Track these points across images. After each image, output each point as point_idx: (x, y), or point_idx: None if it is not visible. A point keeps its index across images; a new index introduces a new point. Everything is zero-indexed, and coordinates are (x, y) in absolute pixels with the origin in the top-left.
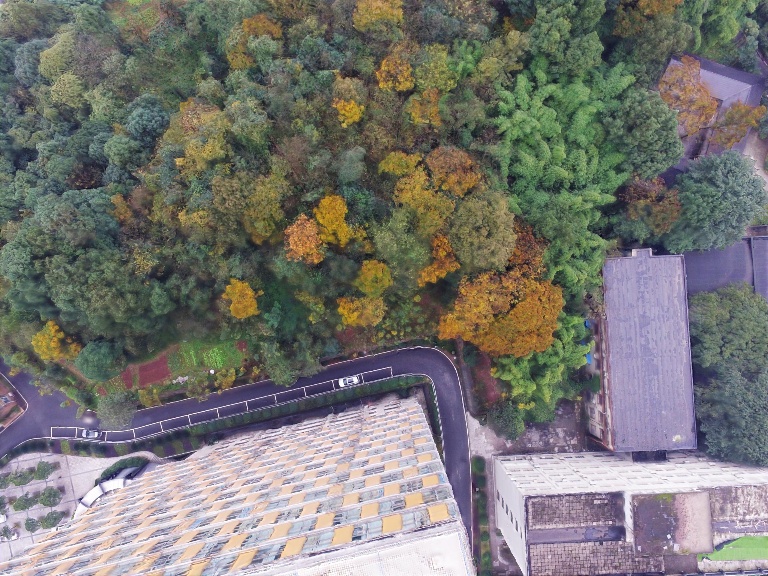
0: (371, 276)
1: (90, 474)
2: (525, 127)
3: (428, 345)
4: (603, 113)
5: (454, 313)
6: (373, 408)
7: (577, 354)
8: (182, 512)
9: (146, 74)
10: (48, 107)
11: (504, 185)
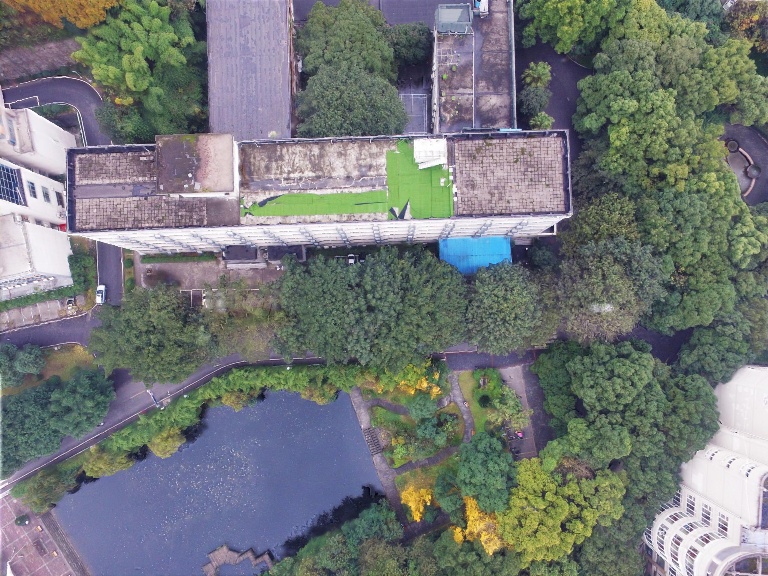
0: None
1: None
2: None
3: (73, 75)
4: None
5: None
6: None
7: (160, 40)
8: None
9: None
10: None
11: None
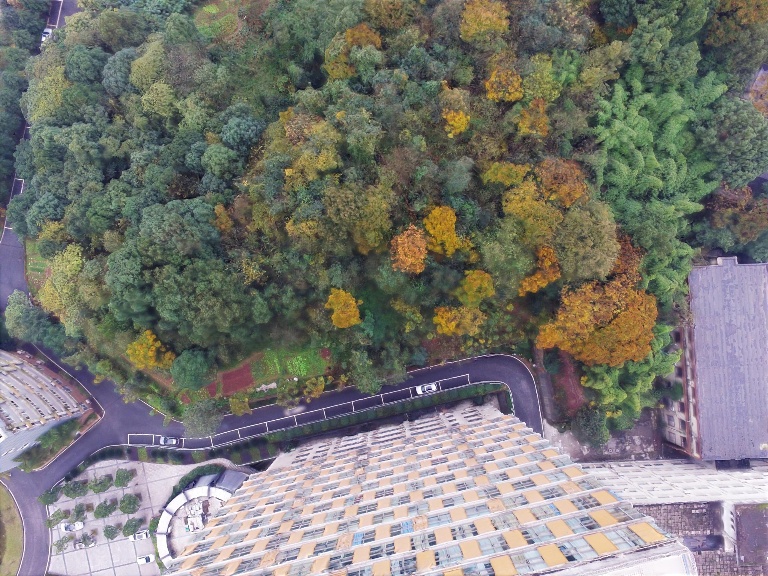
0: (477, 286)
1: (167, 481)
2: (622, 136)
3: (505, 352)
4: (694, 122)
5: (555, 323)
6: (449, 415)
7: (667, 363)
8: (329, 525)
9: (229, 82)
10: (139, 116)
11: (598, 194)
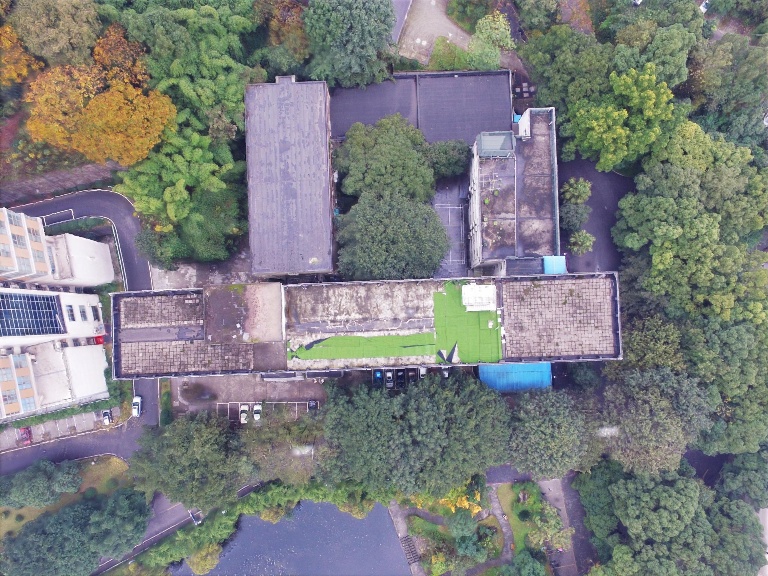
0: None
1: None
2: None
3: (108, 188)
4: None
5: (34, 109)
6: None
7: (202, 171)
8: None
9: None
10: None
11: None
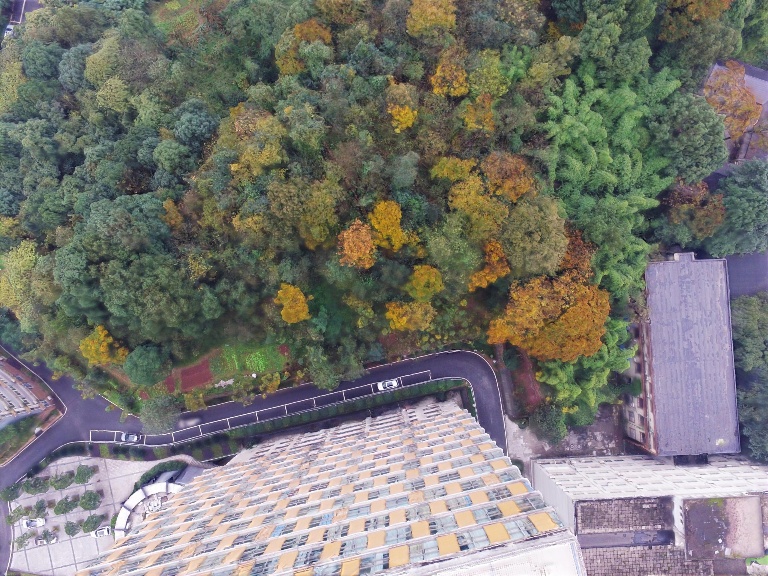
0: (424, 281)
1: (129, 478)
2: (573, 132)
3: (467, 349)
4: (648, 118)
5: (505, 318)
6: (411, 412)
7: (622, 358)
8: (256, 518)
9: (188, 78)
10: (94, 112)
11: (551, 190)
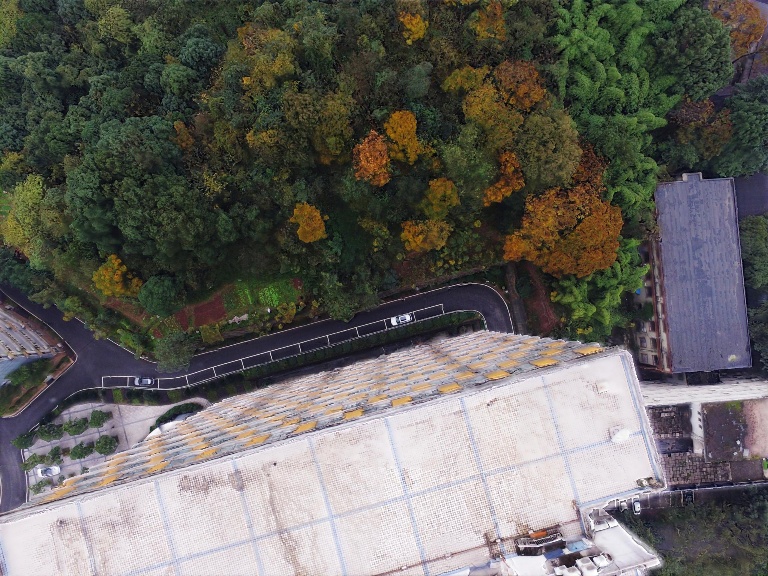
0: (441, 193)
1: (143, 423)
2: (583, 46)
3: (478, 281)
4: (655, 34)
5: (521, 231)
6: None
7: (635, 276)
8: (290, 404)
9: (189, 12)
10: (96, 43)
11: (561, 107)
